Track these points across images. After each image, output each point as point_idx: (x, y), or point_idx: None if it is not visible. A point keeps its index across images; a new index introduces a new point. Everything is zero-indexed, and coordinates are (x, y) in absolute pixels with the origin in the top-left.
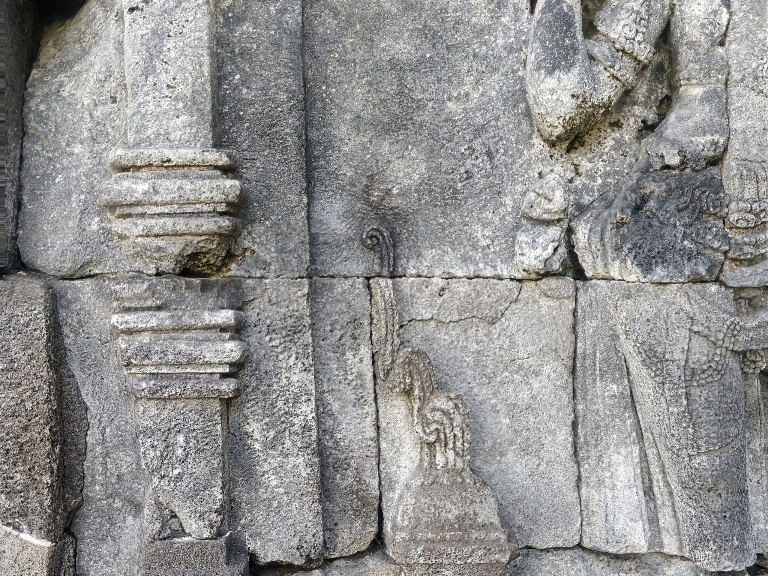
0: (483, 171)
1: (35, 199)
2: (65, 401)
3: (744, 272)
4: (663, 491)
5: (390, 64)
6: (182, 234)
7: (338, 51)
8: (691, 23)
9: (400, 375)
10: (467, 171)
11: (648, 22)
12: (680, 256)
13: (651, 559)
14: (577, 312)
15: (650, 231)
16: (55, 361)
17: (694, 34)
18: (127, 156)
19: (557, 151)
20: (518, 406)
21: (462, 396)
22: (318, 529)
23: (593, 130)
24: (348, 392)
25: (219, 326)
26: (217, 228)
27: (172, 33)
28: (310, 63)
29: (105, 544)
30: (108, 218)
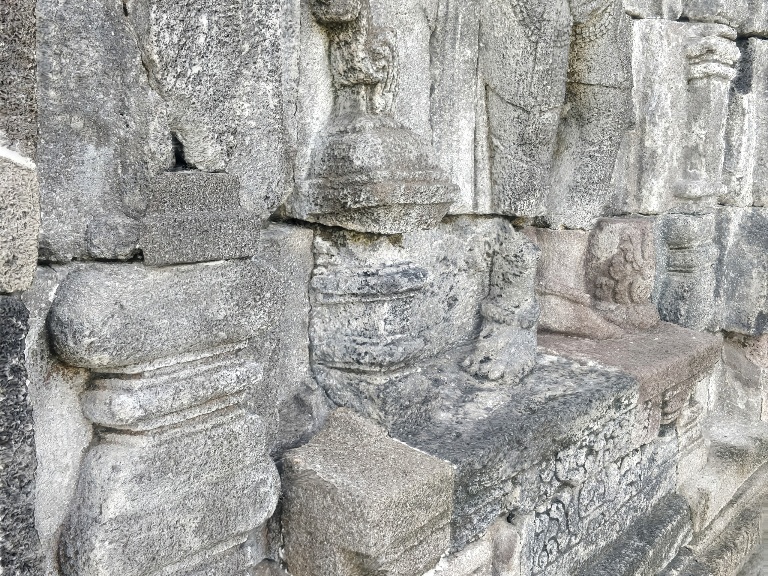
0: None
1: None
2: None
3: None
4: (485, 156)
5: None
6: None
7: None
8: None
9: None
10: None
11: None
12: None
13: (462, 221)
14: None
15: None
16: None
17: None
18: None
19: None
20: None
21: None
22: (282, 176)
23: None
24: None
25: None
26: None
27: None
28: None
29: (58, 186)
30: None
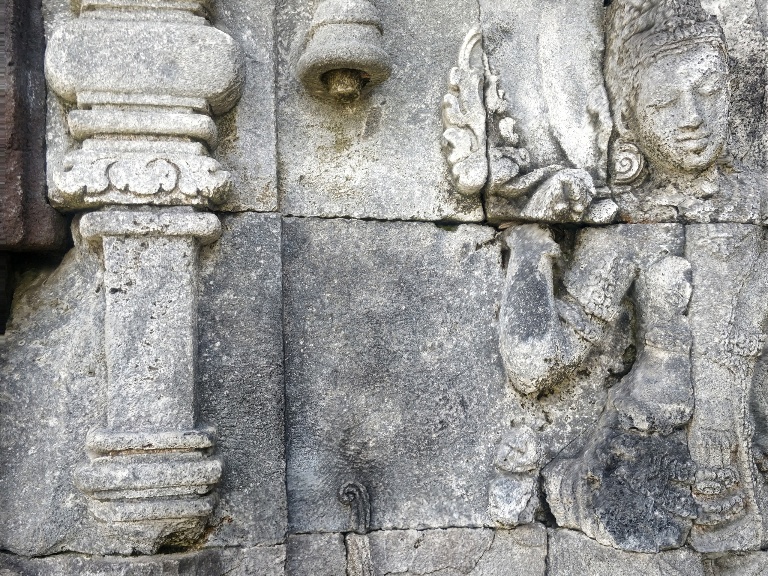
0: (457, 421)
1: (6, 472)
2: None
3: (711, 538)
4: None
5: (367, 317)
6: (161, 518)
7: (316, 306)
8: (656, 290)
9: None
10: (441, 421)
11: (615, 286)
12: (651, 527)
13: None
14: (549, 558)
15: (622, 499)
16: None
17: (659, 301)
18: (107, 442)
19: (528, 400)
20: None
21: None
22: None
23: None
24: None
25: None
26: (198, 512)
27: (155, 314)
28: (288, 319)
29: None
30: (84, 497)
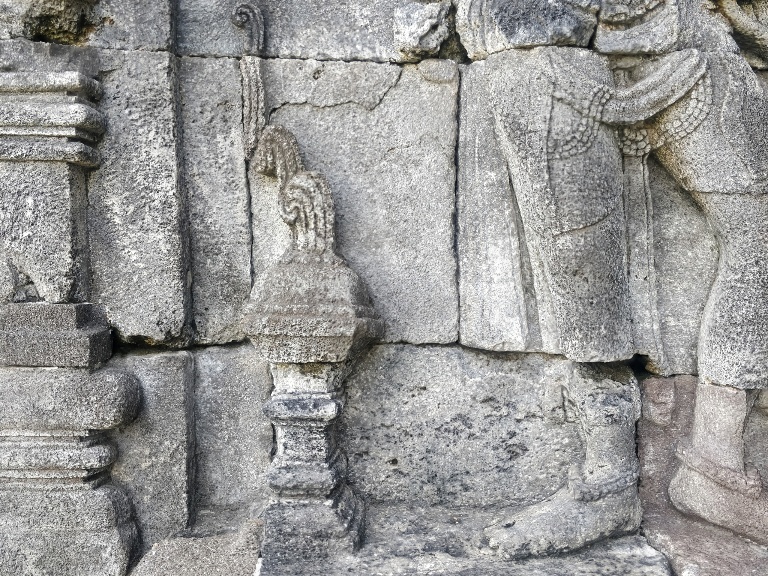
0: None
1: None
2: None
3: (617, 35)
4: (543, 286)
5: None
6: None
7: None
8: None
9: (261, 152)
10: None
11: None
12: (544, 16)
13: (533, 360)
14: (461, 98)
15: None
16: None
17: None
18: None
19: None
20: (396, 196)
21: None
22: (178, 306)
23: None
24: (219, 176)
25: (64, 88)
26: None
27: None
28: None
29: None
30: None
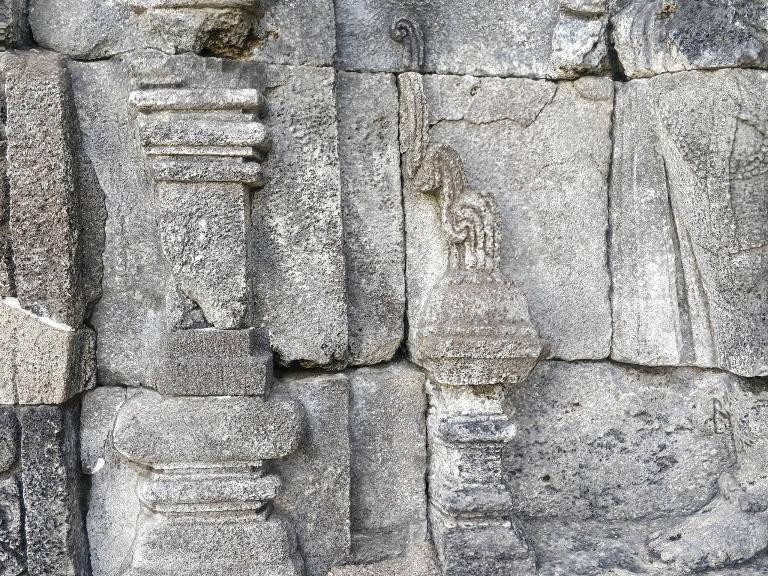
0: None
1: None
2: (82, 187)
3: None
4: (698, 301)
5: None
6: (202, 6)
7: None
8: None
9: (429, 171)
10: None
11: None
12: (730, 38)
13: (682, 373)
14: (615, 116)
15: (699, 13)
16: (71, 142)
17: None
18: None
19: None
20: (550, 213)
21: (493, 196)
22: (343, 328)
23: None
24: (374, 194)
25: (242, 106)
26: None
27: None
28: None
29: (126, 337)
30: None
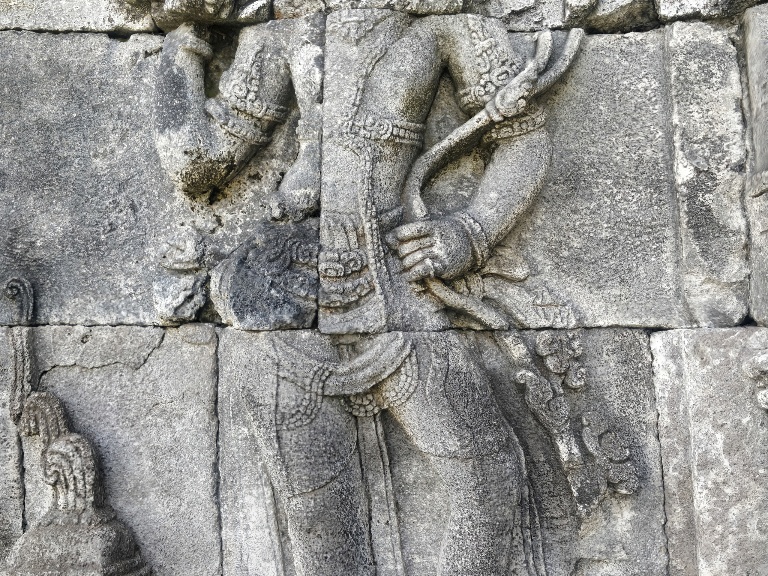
0: (127, 223)
1: None
2: None
3: (334, 319)
4: None
5: (37, 124)
6: None
7: None
8: (297, 82)
9: (24, 419)
10: (111, 223)
11: (263, 81)
12: (267, 305)
13: None
14: None
15: (245, 281)
16: None
17: (300, 92)
18: None
19: (198, 203)
20: (160, 448)
21: None
22: None
23: (233, 183)
24: None
25: None
26: None
27: None
28: None
29: None
30: None
